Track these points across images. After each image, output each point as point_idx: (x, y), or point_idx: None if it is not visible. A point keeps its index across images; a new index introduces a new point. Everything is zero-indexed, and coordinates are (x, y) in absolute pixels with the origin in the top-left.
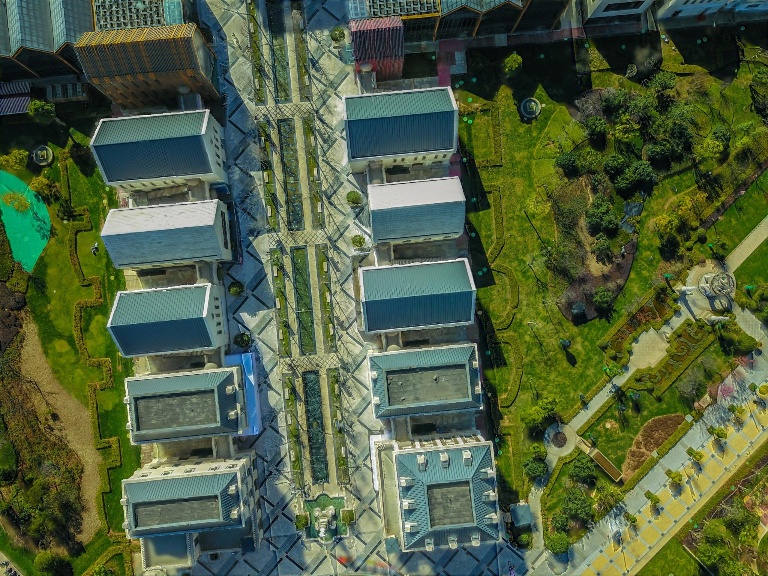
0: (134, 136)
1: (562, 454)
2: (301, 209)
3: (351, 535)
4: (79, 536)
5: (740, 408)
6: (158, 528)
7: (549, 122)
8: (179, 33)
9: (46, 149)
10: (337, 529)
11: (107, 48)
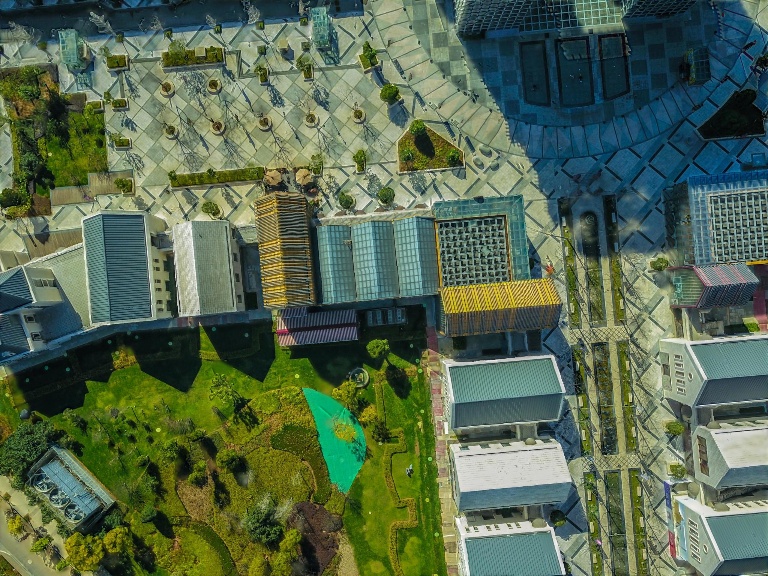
0: (492, 391)
1: None
2: (615, 433)
3: None
4: None
5: None
6: None
7: None
8: (548, 297)
9: (362, 372)
10: None
11: (479, 314)
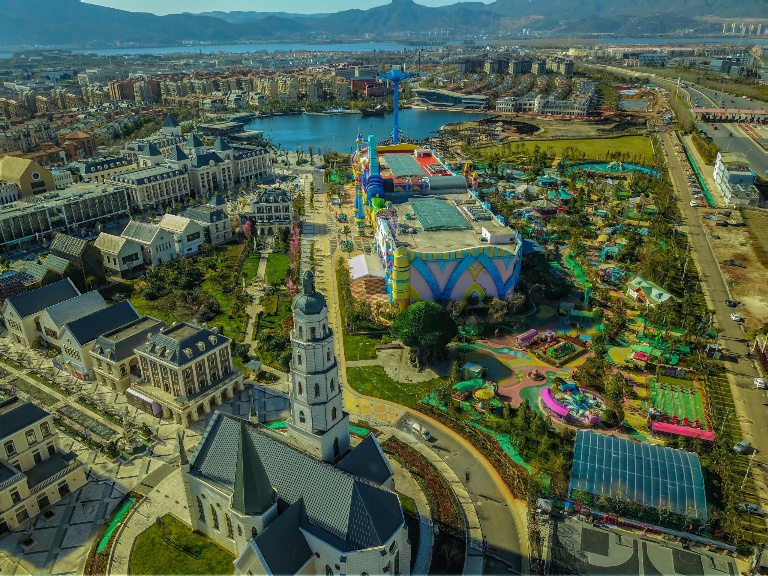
0: None
1: None
2: (4, 370)
3: (159, 441)
4: None
5: None
6: None
7: None
8: None
9: None
10: (146, 445)
11: None
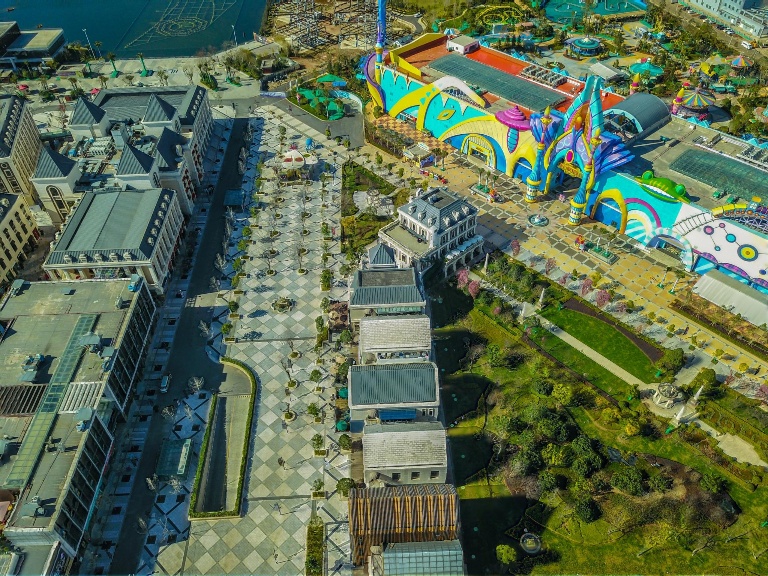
0: None
1: None
2: None
3: None
4: None
5: (766, 383)
6: None
7: (543, 526)
8: None
9: None
10: None
11: None
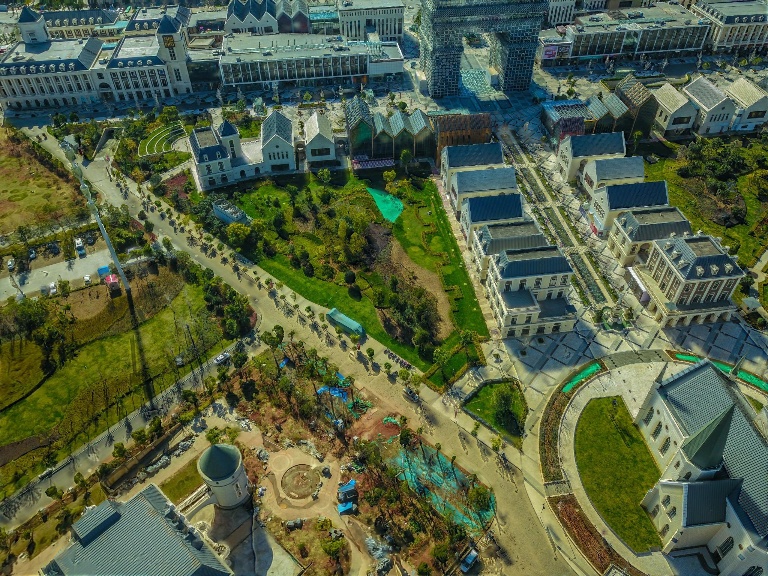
0: None
1: (759, 281)
2: (543, 195)
3: (635, 328)
4: (440, 334)
5: None
6: (524, 261)
7: (665, 162)
8: None
9: (398, 181)
10: (624, 325)
11: (452, 117)
